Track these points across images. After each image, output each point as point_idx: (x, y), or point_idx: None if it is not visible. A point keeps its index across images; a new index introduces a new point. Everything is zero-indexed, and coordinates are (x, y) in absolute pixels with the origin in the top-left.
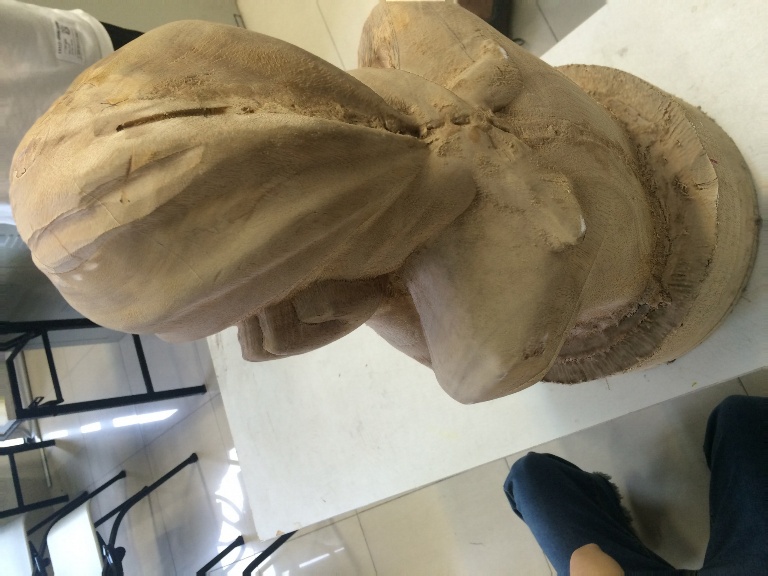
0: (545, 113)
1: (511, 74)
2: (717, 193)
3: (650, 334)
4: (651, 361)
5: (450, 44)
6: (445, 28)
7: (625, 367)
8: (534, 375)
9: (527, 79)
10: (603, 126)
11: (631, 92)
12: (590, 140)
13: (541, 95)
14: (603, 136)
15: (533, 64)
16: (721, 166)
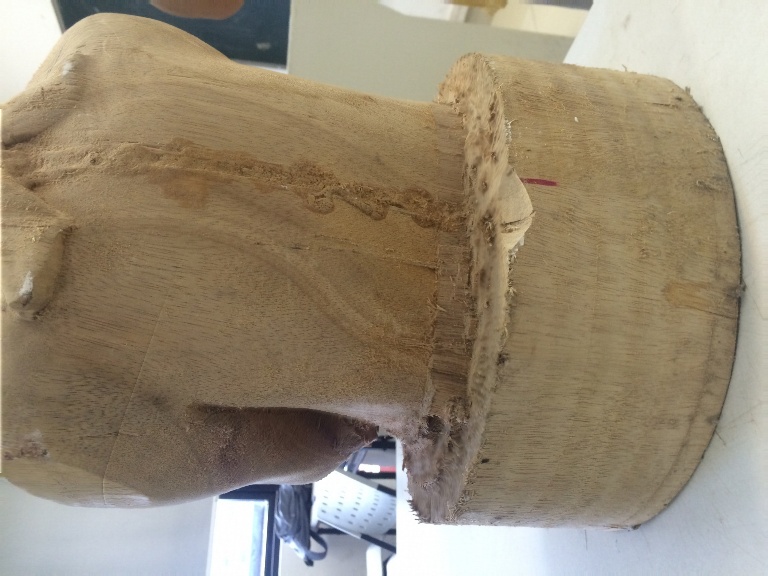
0: (93, 137)
1: (57, 93)
2: (520, 237)
3: (461, 467)
4: (523, 514)
5: (46, 69)
6: (58, 51)
7: (446, 512)
8: (96, 485)
9: (92, 96)
10: (255, 144)
11: (479, 85)
12: (169, 167)
13: (103, 114)
14: (233, 159)
15: (131, 75)
16: (573, 189)
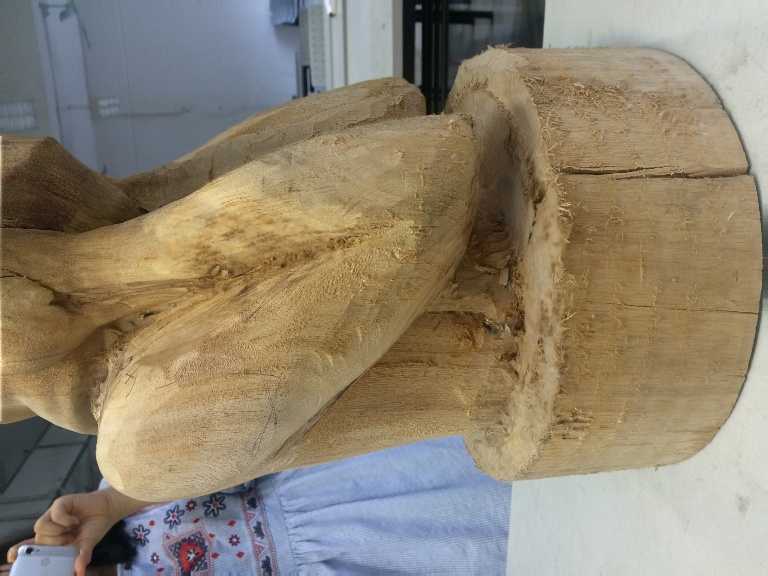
0: None
1: None
2: None
3: None
4: None
5: None
6: None
7: None
8: None
9: None
10: None
11: (494, 462)
12: None
13: None
14: None
15: None
16: None
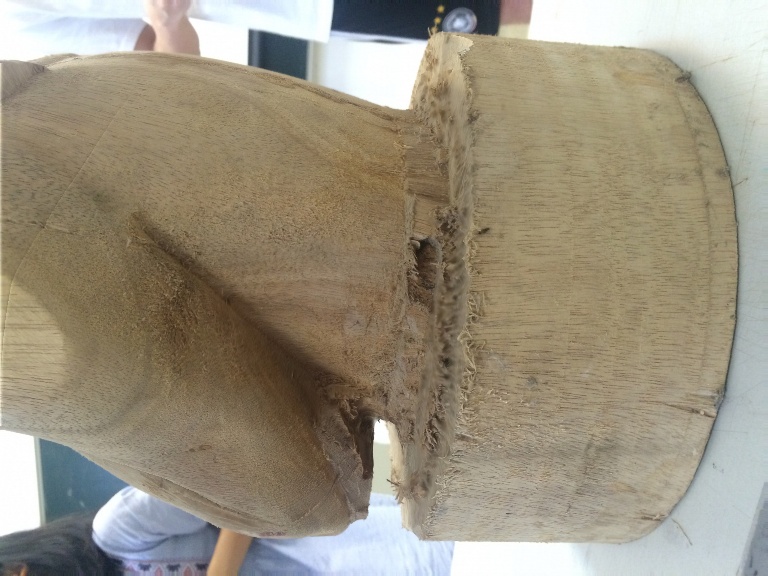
0: None
1: None
2: None
3: (463, 286)
4: (561, 364)
5: None
6: None
7: None
8: None
9: None
10: None
11: None
12: None
13: None
14: None
15: None
16: None
